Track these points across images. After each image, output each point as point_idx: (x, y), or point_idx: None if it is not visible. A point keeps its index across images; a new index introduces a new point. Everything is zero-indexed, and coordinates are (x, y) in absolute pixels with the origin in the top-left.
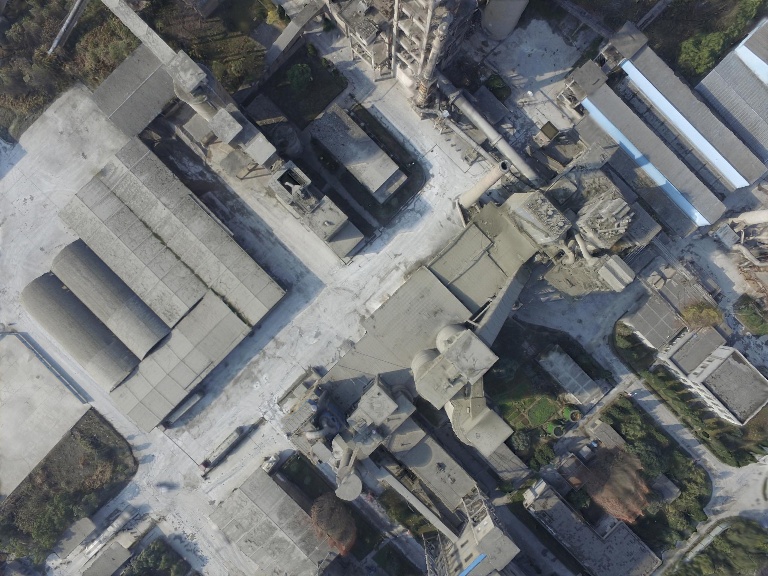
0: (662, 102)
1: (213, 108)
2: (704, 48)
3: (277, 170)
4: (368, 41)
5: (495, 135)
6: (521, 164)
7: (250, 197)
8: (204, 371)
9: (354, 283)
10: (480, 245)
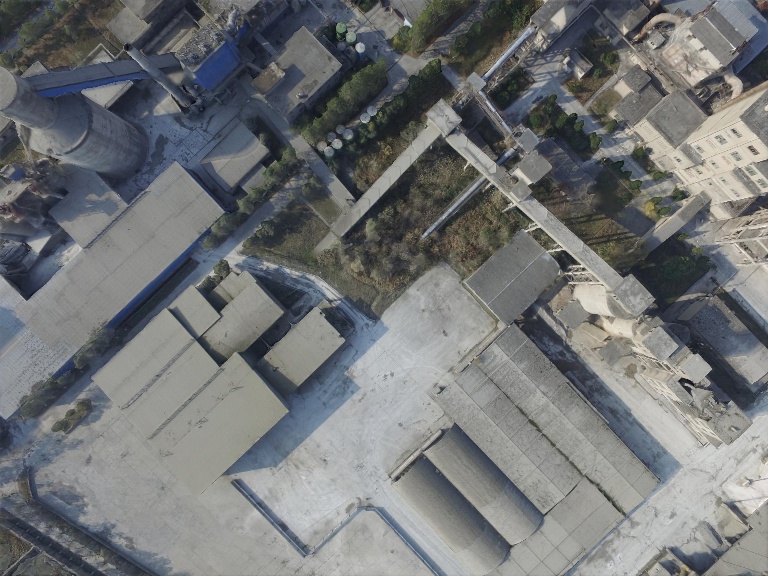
0: None
1: None
2: None
3: None
4: None
5: None
6: None
7: (609, 377)
8: (576, 558)
9: (711, 465)
10: None
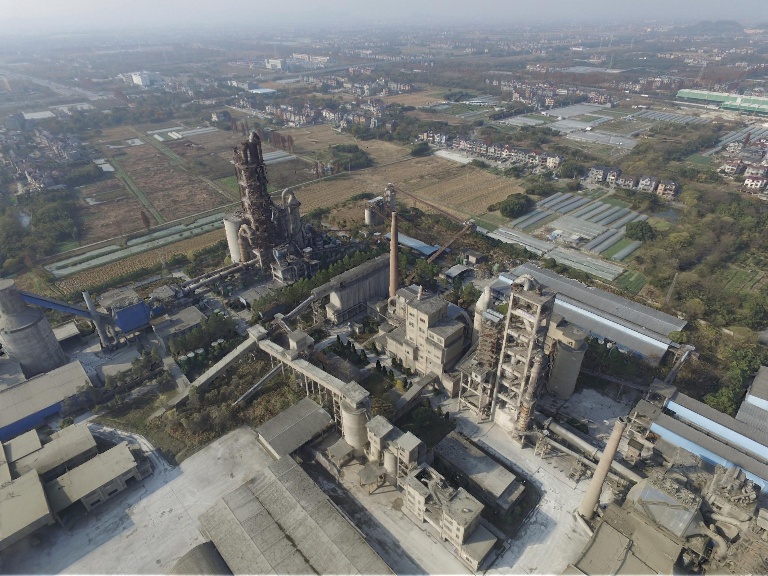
0: (715, 427)
1: (364, 423)
2: (721, 397)
3: (414, 469)
4: (482, 378)
5: (592, 448)
6: (624, 469)
7: (377, 510)
8: None
9: None
10: (620, 543)
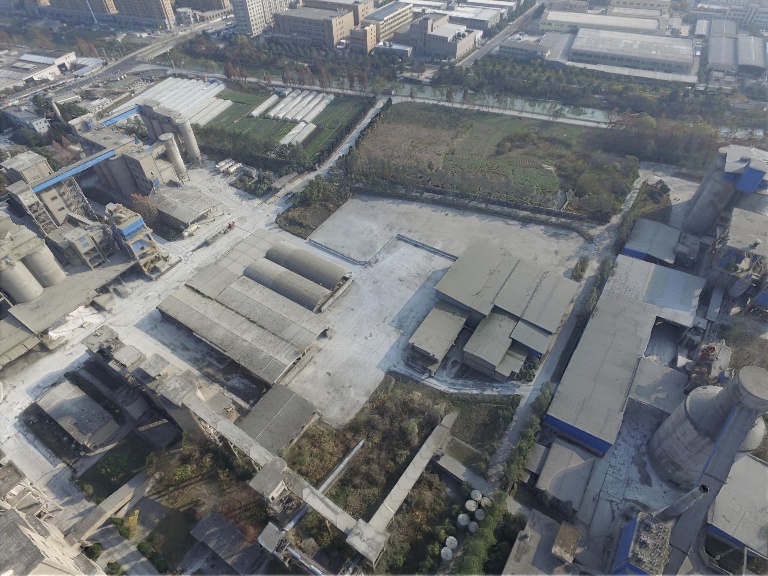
0: None
1: None
2: None
3: None
4: None
5: None
6: None
7: None
8: (221, 259)
9: None
10: None
